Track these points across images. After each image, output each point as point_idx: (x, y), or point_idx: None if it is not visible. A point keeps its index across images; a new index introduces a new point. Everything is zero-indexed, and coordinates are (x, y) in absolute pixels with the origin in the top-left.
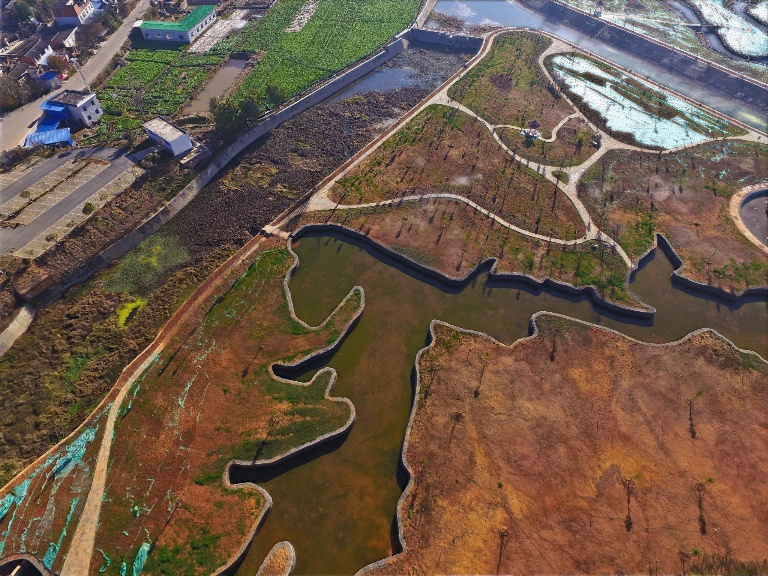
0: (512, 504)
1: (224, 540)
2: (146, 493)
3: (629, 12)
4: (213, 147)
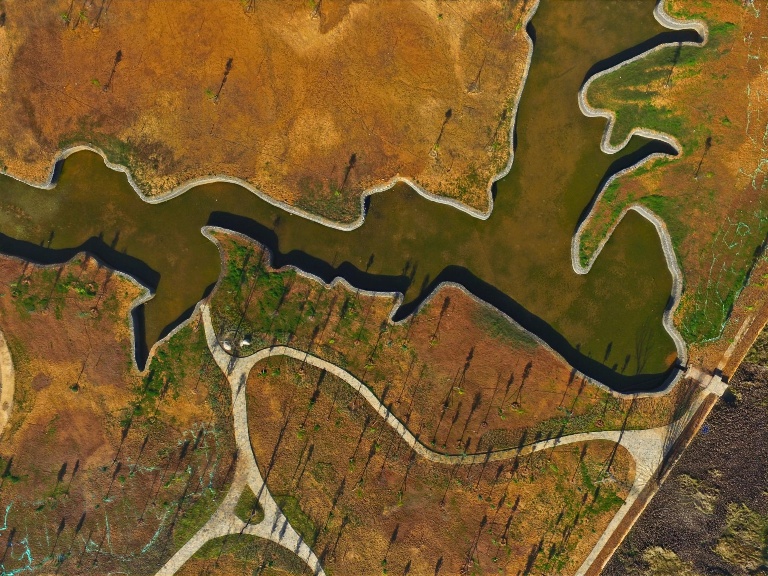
0: None
1: None
2: None
3: None
4: None
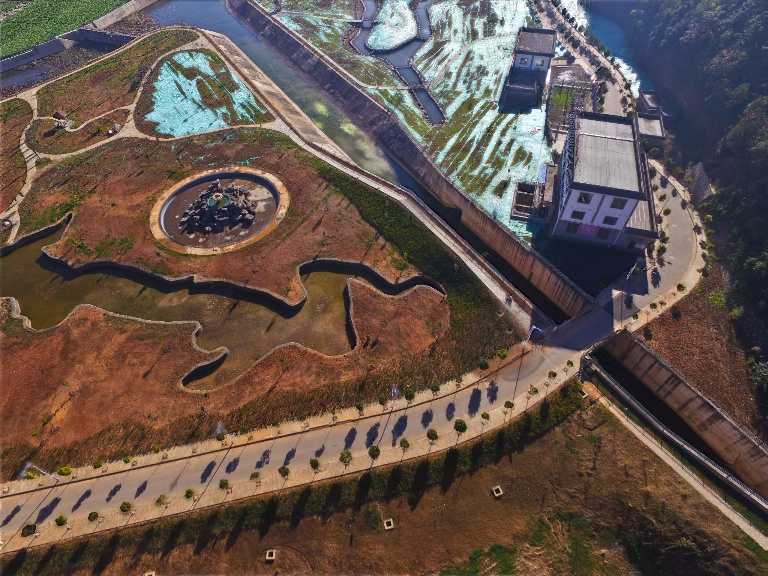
0: None
1: None
2: None
3: (308, 10)
4: None
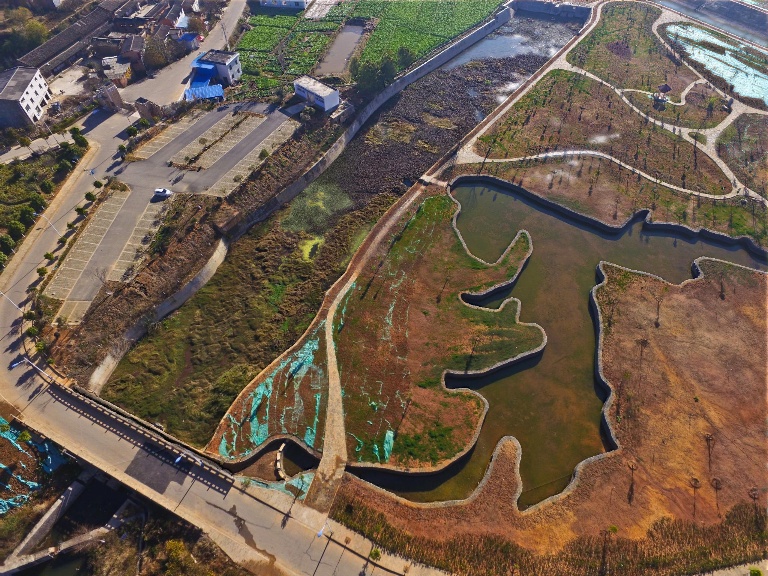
0: (711, 415)
1: (456, 432)
2: (379, 392)
3: None
4: (355, 105)
